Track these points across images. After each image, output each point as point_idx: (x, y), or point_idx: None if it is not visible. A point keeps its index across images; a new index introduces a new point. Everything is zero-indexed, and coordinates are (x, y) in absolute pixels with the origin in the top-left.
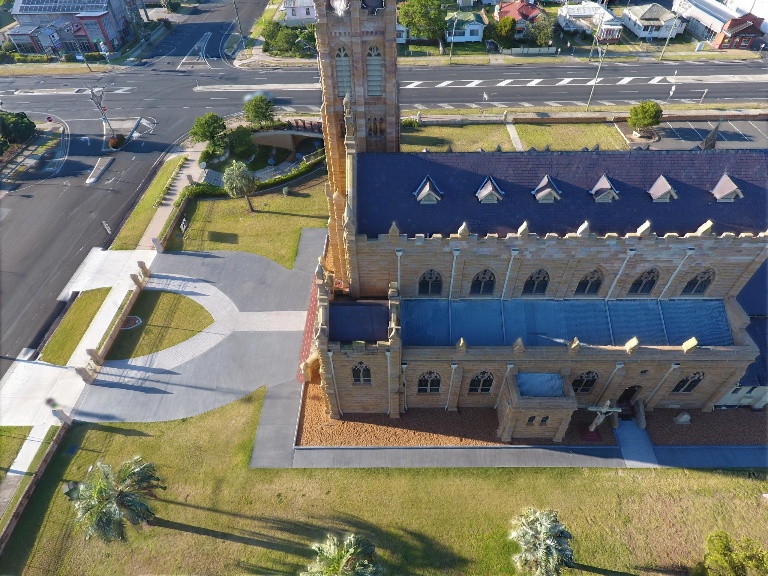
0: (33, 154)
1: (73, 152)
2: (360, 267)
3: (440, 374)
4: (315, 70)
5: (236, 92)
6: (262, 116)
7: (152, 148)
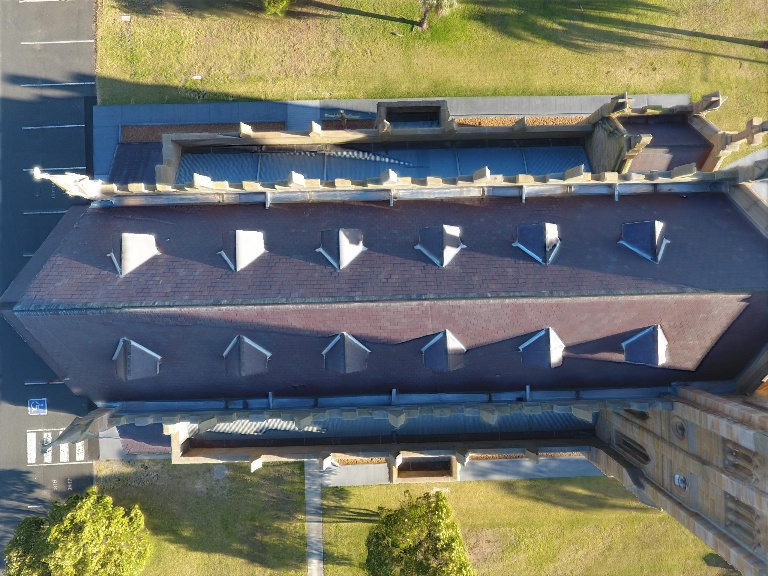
0: None
1: None
2: None
3: None
4: None
5: None
6: None
7: None
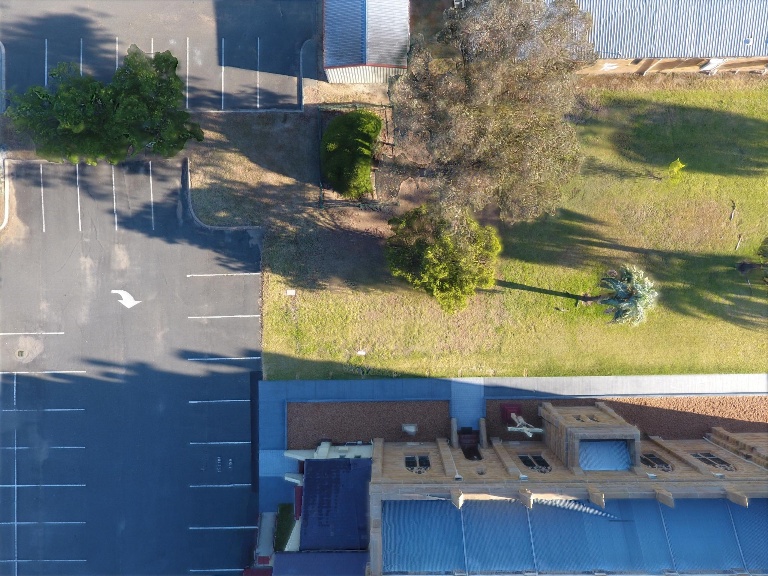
0: None
1: None
2: None
3: None
4: None
5: None
6: None
7: None
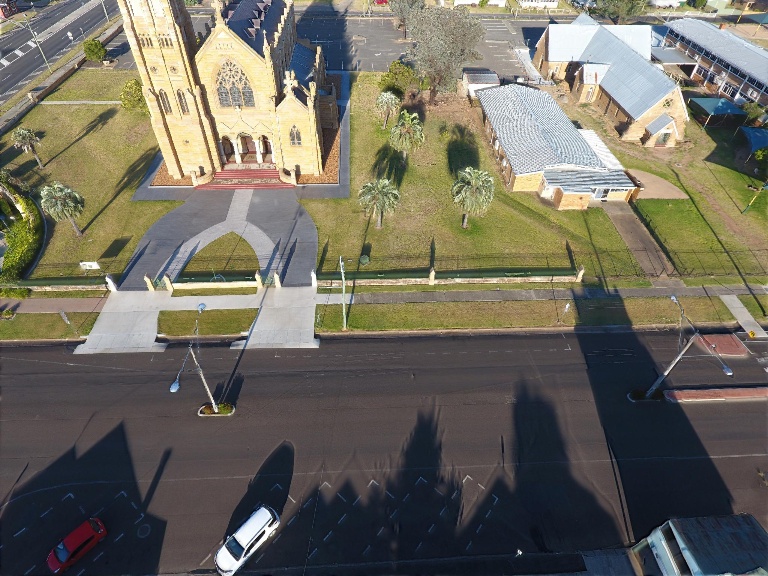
0: None
1: None
2: None
3: None
4: None
5: None
6: None
7: None
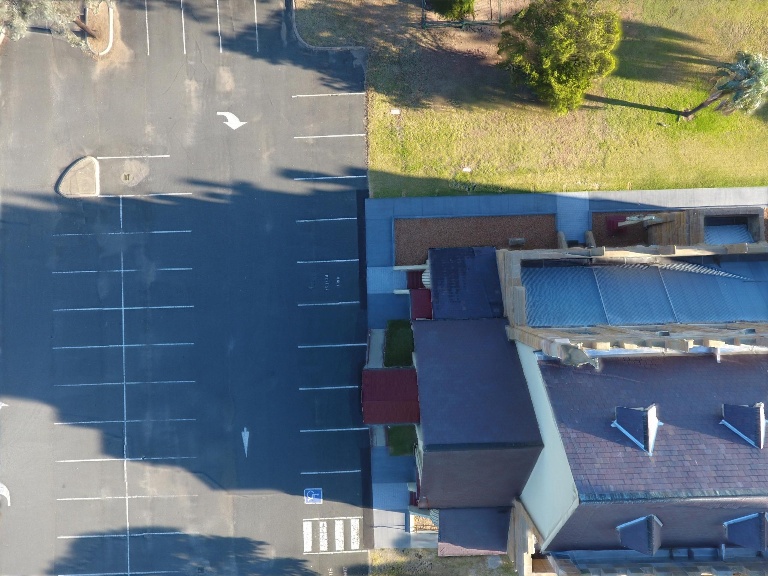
0: None
1: None
2: None
3: None
4: None
5: None
6: None
7: None
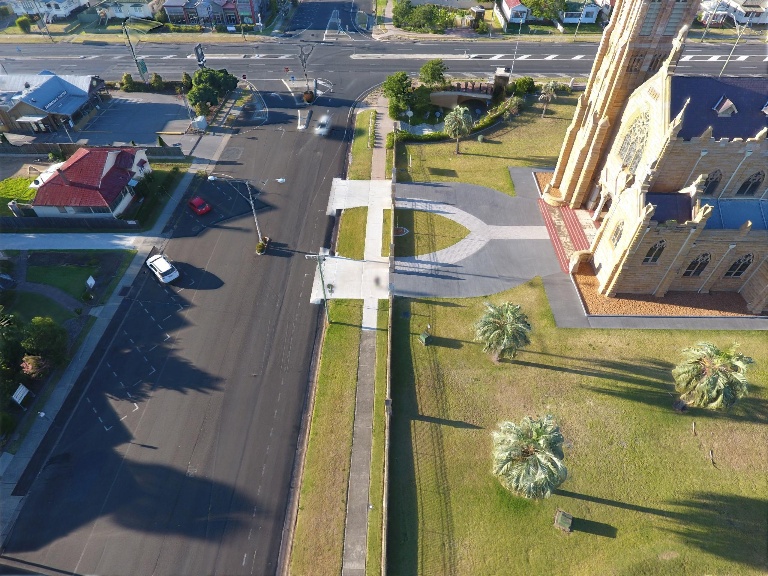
0: (235, 106)
1: (270, 105)
2: (663, 167)
3: (713, 256)
4: (452, 44)
5: (391, 60)
6: (437, 78)
7: (339, 103)
